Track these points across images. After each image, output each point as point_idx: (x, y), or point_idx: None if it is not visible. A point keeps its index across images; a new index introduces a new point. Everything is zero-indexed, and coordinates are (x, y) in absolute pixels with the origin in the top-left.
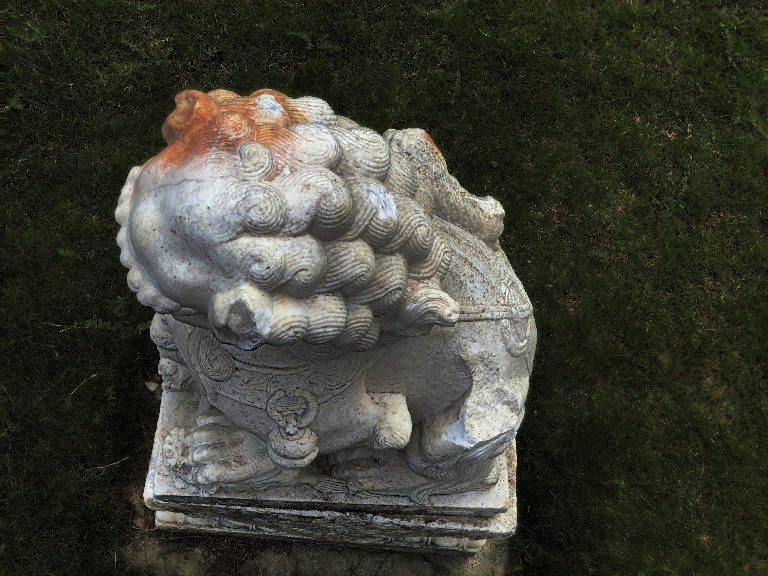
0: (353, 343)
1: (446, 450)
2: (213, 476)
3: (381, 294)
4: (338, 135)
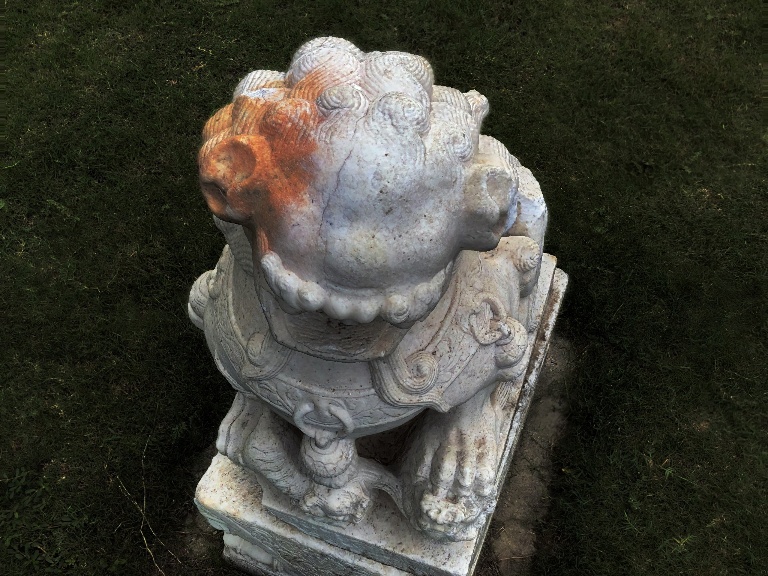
0: None
1: (539, 231)
2: (490, 473)
3: None
4: None
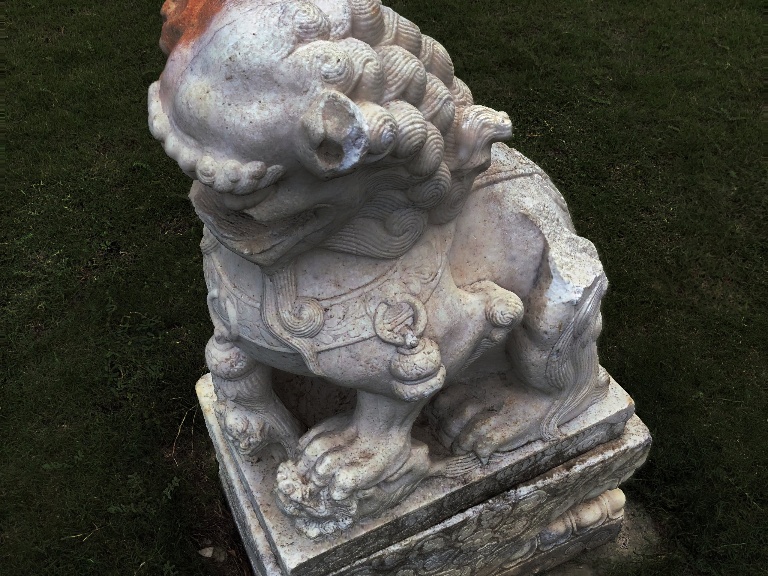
0: (437, 164)
1: (558, 316)
2: (348, 480)
3: (438, 105)
4: None
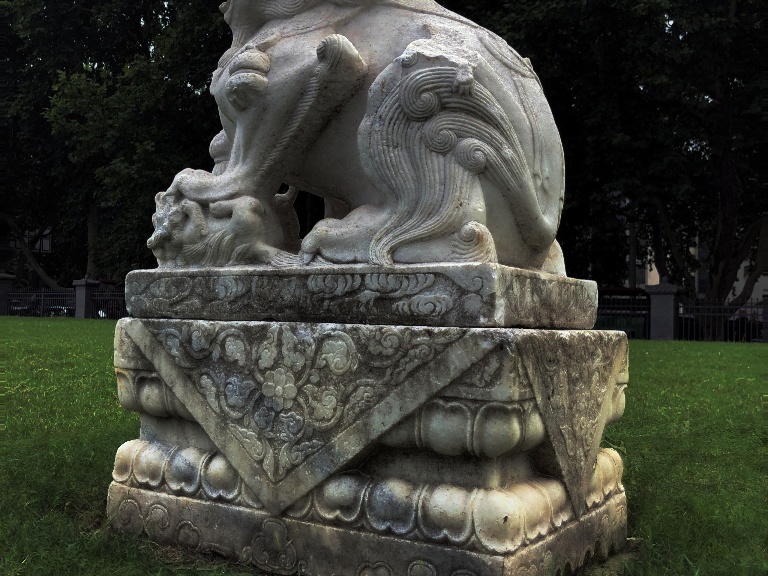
0: None
1: None
2: None
3: None
4: None
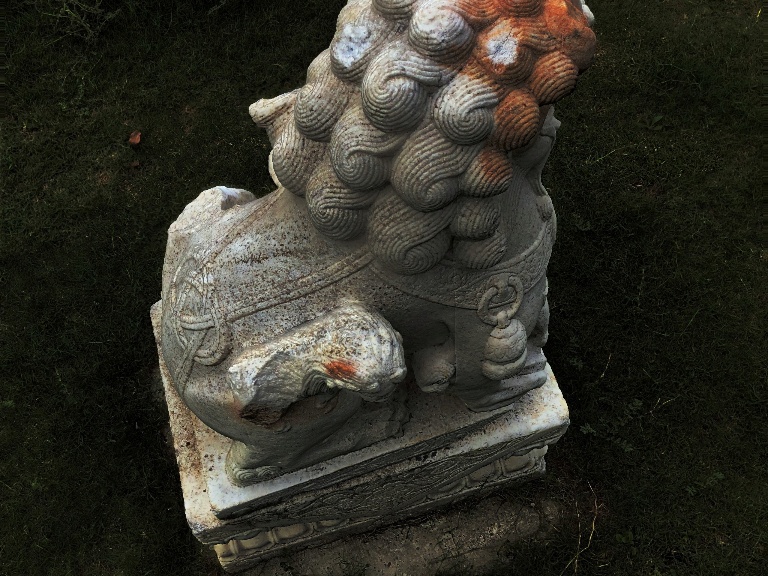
0: None
1: None
2: None
3: None
4: (424, 63)
